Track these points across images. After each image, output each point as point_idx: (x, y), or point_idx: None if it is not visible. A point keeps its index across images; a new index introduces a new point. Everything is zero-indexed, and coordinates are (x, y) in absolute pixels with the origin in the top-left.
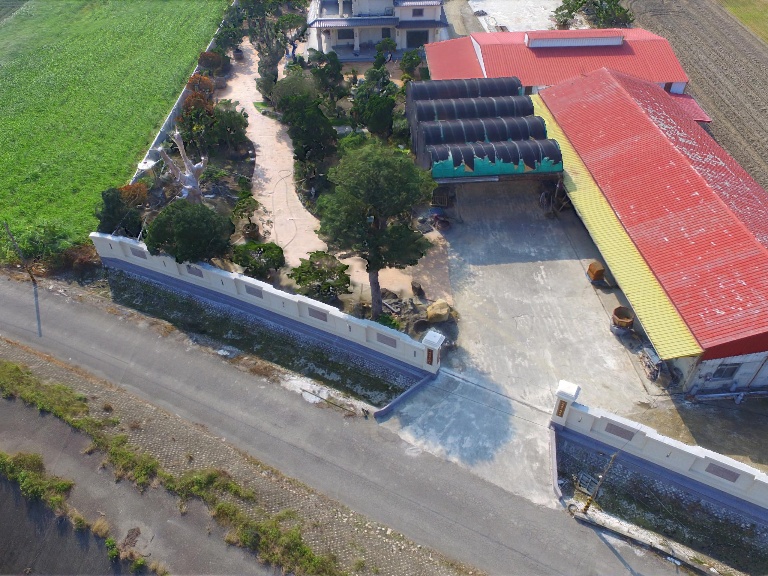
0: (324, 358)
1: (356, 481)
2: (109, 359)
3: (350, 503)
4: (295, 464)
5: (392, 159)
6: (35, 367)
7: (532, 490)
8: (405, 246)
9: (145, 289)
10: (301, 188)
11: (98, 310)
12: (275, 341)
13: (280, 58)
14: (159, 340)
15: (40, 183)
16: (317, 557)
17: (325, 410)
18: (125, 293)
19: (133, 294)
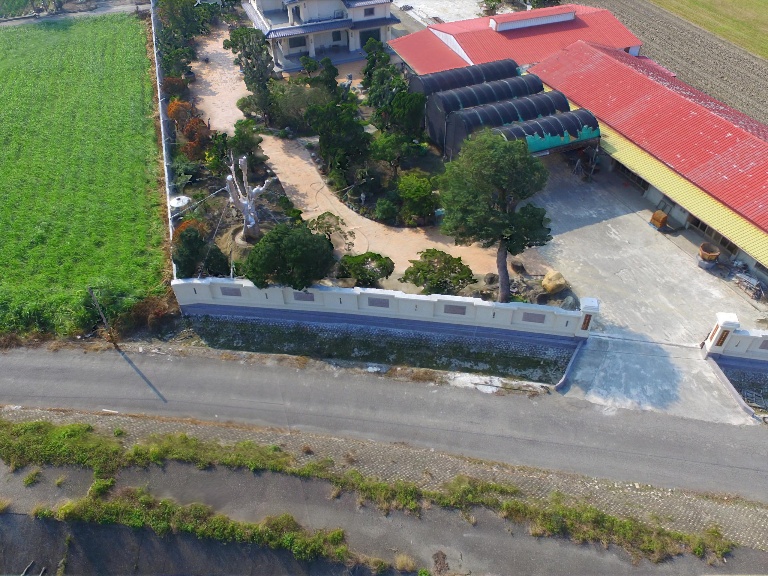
0: (465, 351)
1: (579, 451)
2: (260, 405)
3: (587, 472)
4: (515, 452)
5: (511, 143)
6: (192, 433)
7: (726, 415)
8: (540, 224)
9: (241, 329)
10: (346, 197)
11: (211, 360)
12: (407, 347)
13: (270, 71)
14: (299, 374)
15: (52, 244)
16: (626, 522)
17: (508, 396)
18: (219, 338)
19: (229, 337)
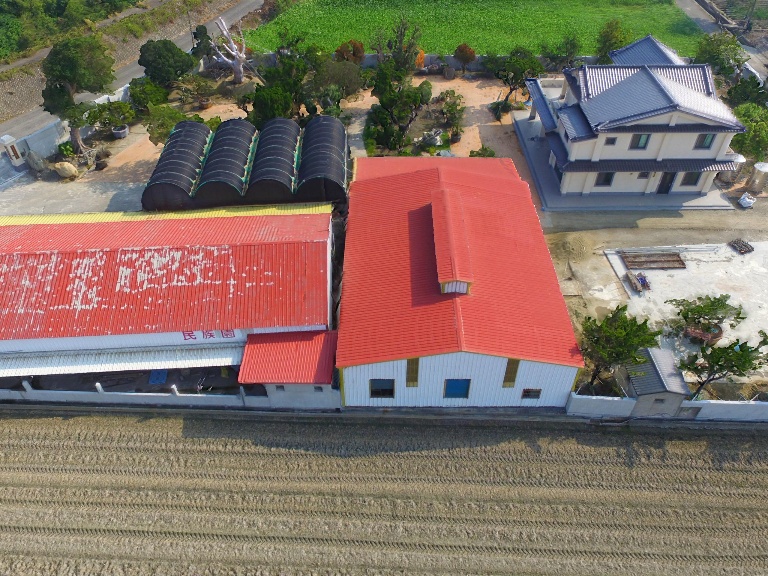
0: None
1: None
2: None
3: None
4: None
5: (77, 52)
6: None
7: None
8: None
9: None
10: None
11: None
12: None
13: None
14: None
15: None
16: None
17: None
18: None
19: None
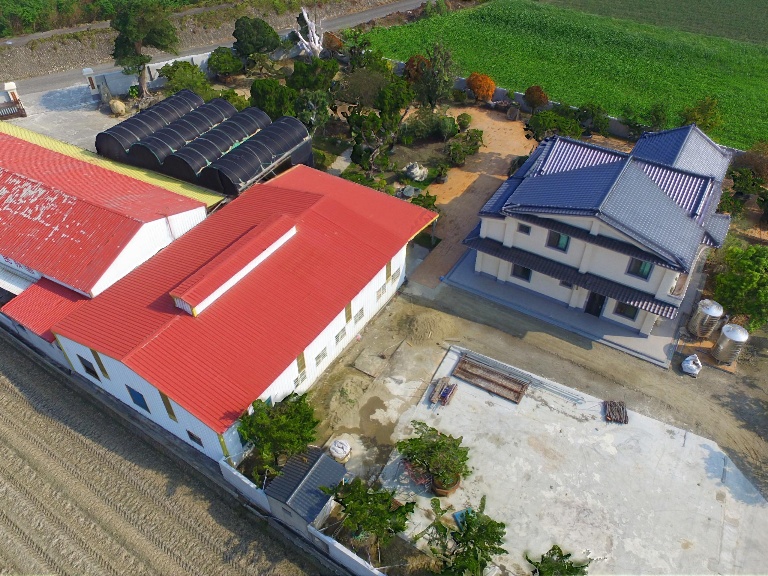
0: None
1: None
2: None
3: None
4: None
5: (134, 11)
6: None
7: None
8: None
9: None
10: None
11: None
12: None
13: None
14: None
15: None
16: None
17: None
18: None
19: None
